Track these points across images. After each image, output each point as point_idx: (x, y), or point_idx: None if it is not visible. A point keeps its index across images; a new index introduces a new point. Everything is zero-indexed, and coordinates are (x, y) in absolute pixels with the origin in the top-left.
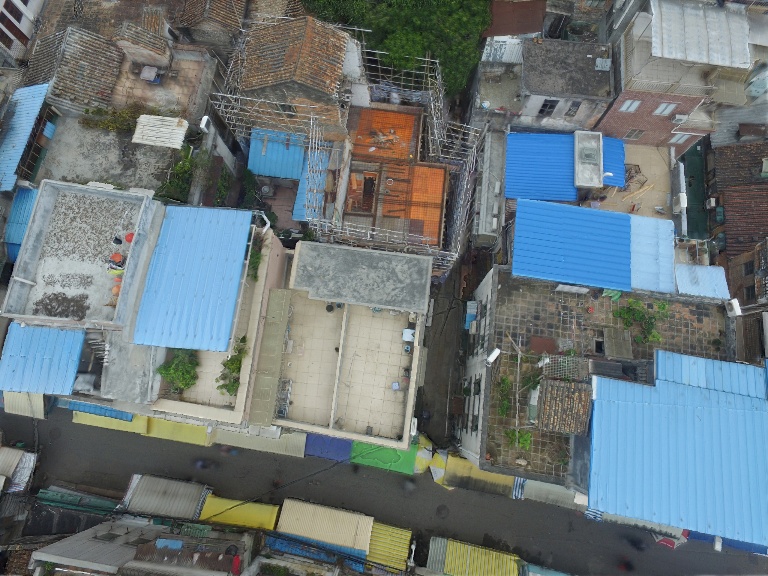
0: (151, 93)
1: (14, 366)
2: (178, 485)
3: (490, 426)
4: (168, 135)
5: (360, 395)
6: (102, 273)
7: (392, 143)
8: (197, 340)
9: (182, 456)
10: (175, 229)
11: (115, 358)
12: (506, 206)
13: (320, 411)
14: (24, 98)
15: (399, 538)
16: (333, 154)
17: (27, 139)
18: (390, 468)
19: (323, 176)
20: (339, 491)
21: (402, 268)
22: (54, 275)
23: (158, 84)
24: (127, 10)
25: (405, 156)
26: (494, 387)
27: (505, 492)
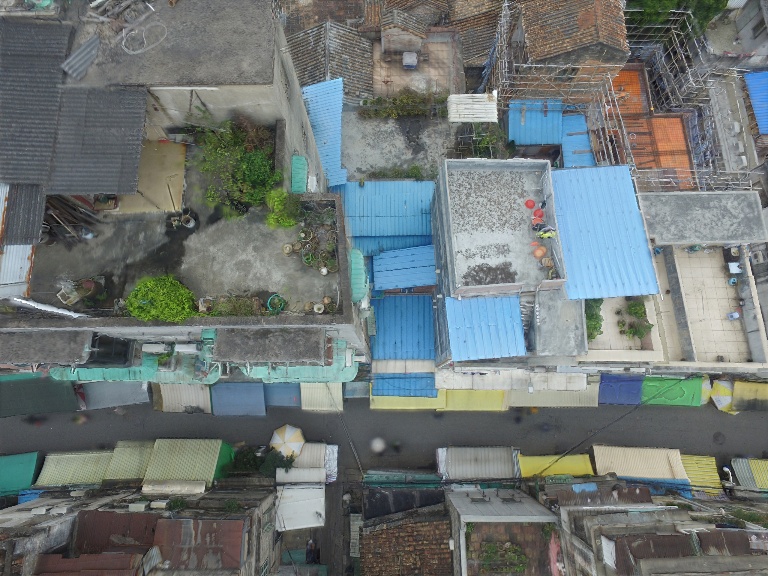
0: (409, 79)
1: (464, 337)
2: (486, 451)
3: None
4: (483, 111)
5: (701, 330)
6: (516, 240)
7: (624, 100)
8: (627, 287)
9: (461, 427)
10: (563, 191)
11: (546, 317)
12: (758, 142)
13: (669, 350)
14: (314, 96)
15: (706, 464)
16: (589, 115)
17: (340, 133)
18: (679, 403)
19: (584, 137)
20: (618, 435)
21: (733, 205)
22: (470, 249)
23: (414, 69)
24: (327, 5)
25: (640, 110)
26: None
27: None
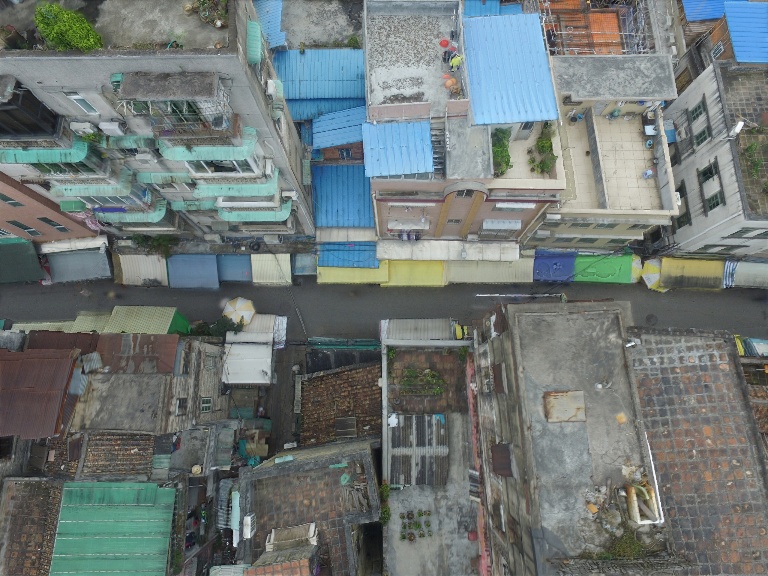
0: None
1: (377, 156)
2: (425, 321)
3: (744, 187)
4: None
5: (617, 187)
6: (429, 74)
7: None
8: (530, 114)
9: (407, 309)
10: (476, 35)
11: (455, 144)
12: (686, 31)
13: (586, 204)
14: None
15: None
16: None
17: (281, 2)
18: (610, 280)
19: None
20: None
21: (646, 66)
22: (387, 81)
23: None
24: None
25: (578, 6)
26: (739, 157)
27: (716, 284)
